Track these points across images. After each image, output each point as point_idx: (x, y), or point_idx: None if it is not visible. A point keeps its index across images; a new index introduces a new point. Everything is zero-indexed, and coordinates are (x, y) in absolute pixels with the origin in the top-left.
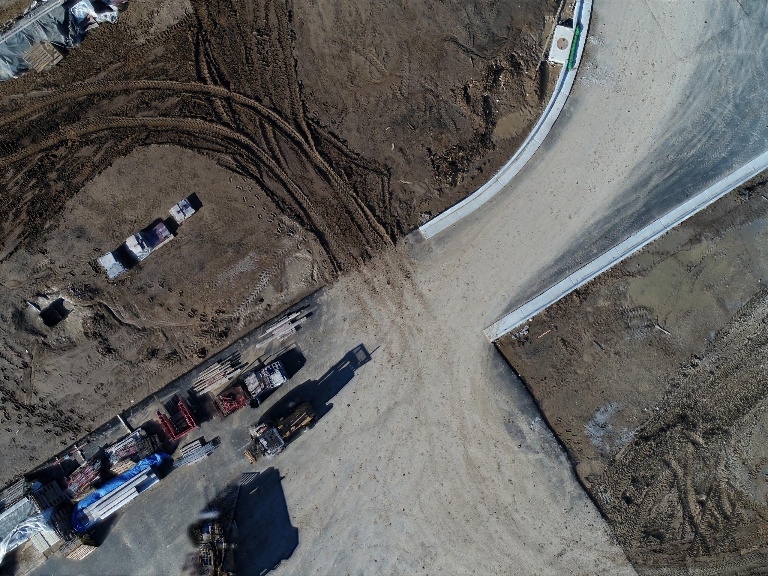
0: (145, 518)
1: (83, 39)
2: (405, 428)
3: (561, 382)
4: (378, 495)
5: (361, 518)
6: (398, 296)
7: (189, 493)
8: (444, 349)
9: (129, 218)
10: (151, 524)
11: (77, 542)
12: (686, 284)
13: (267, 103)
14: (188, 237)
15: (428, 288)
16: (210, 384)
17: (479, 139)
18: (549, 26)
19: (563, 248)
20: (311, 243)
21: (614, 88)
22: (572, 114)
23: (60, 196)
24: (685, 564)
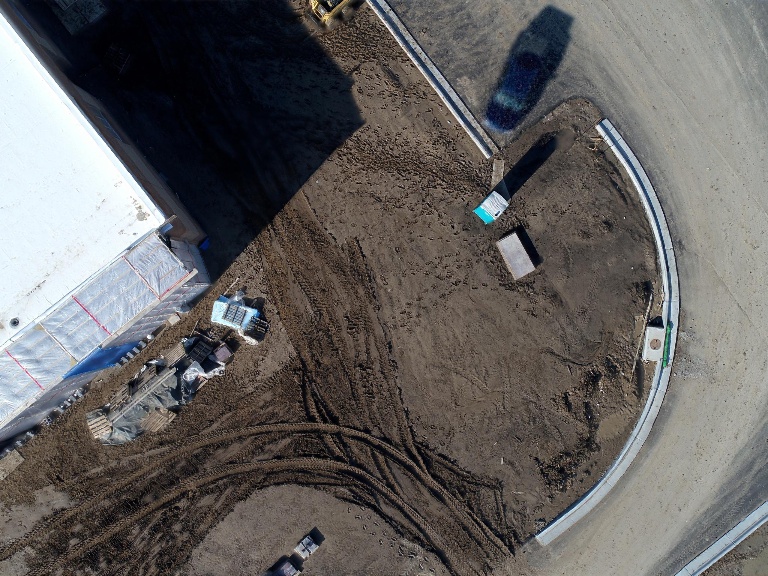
0: None
1: (195, 397)
2: None
3: None
4: None
5: None
6: None
7: None
8: None
9: (255, 558)
10: None
11: None
12: None
13: (377, 433)
14: (314, 570)
15: None
16: None
17: (584, 445)
18: (639, 325)
19: (676, 540)
20: (433, 562)
21: (709, 380)
22: (671, 409)
23: (187, 545)
24: None
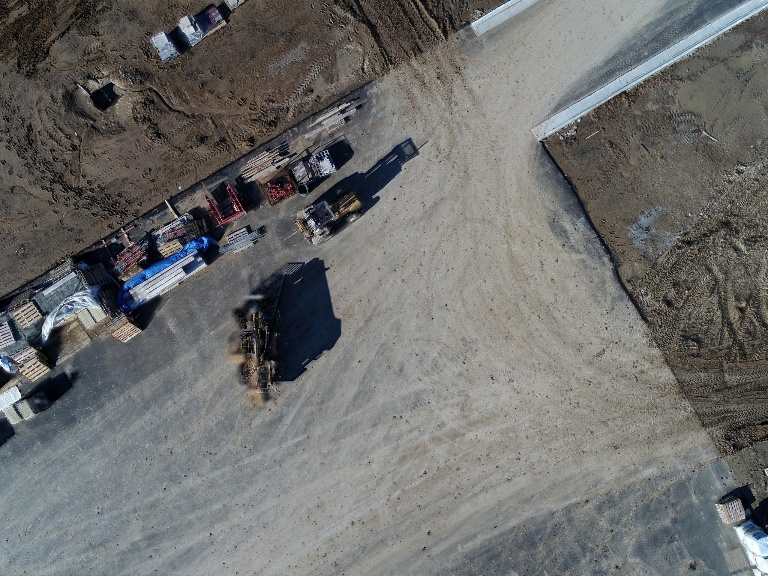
0: (190, 304)
1: None
2: (450, 224)
3: (607, 184)
4: (421, 290)
5: (404, 312)
6: (448, 92)
7: (234, 281)
8: (492, 147)
9: (182, 3)
10: (195, 310)
11: (123, 320)
12: (735, 91)
13: None
14: (240, 25)
15: (478, 85)
16: (258, 171)
17: None
18: None
19: (614, 49)
20: (363, 35)
21: None
22: None
23: None
24: (722, 370)
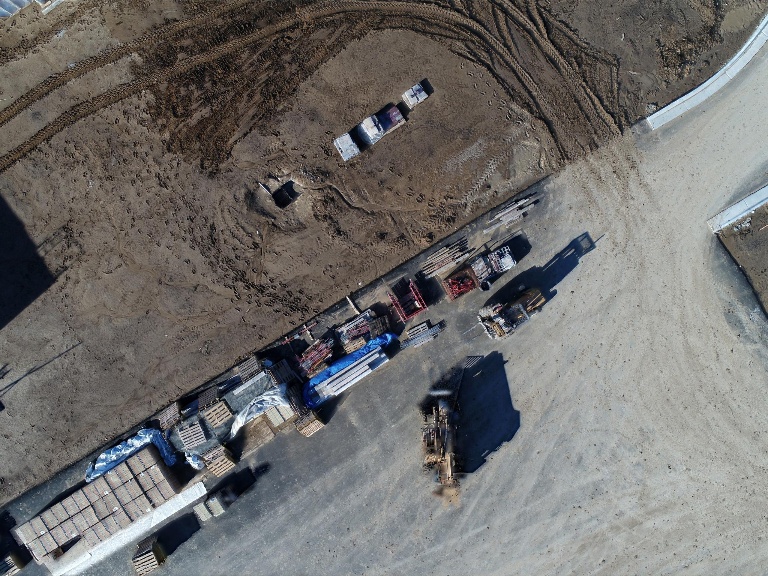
0: (371, 398)
1: None
2: (627, 316)
3: None
4: (599, 381)
5: (581, 403)
6: (624, 185)
7: (414, 375)
8: (667, 239)
9: (361, 102)
10: (377, 404)
11: (311, 417)
12: None
13: None
14: (419, 122)
15: (653, 178)
16: (439, 267)
17: (709, 31)
18: None
19: None
20: (539, 131)
21: None
22: None
23: (294, 78)
24: None
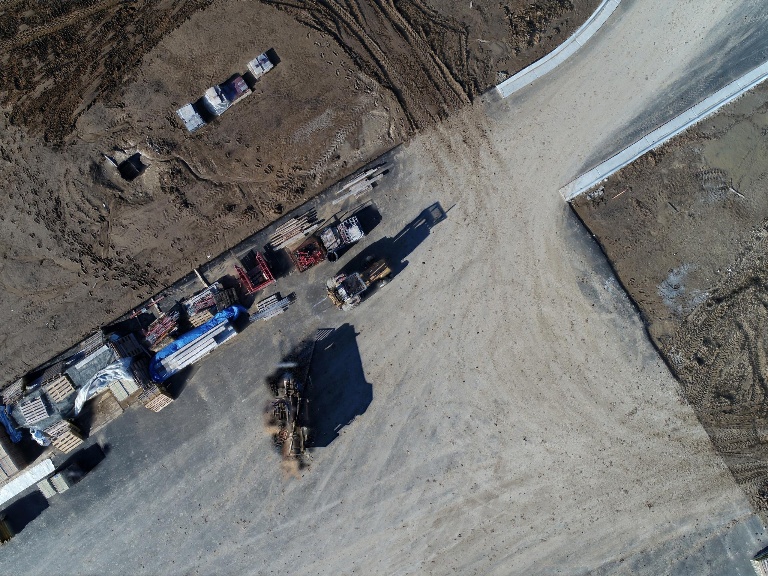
0: (221, 372)
1: None
2: (480, 286)
3: (635, 243)
4: (452, 353)
5: (435, 375)
6: (474, 155)
7: (265, 348)
8: (519, 208)
9: (207, 73)
10: (227, 378)
11: (156, 391)
12: (761, 147)
13: None
14: (266, 93)
15: (504, 147)
16: (287, 239)
17: None
18: None
19: (639, 109)
20: (388, 100)
21: None
22: None
23: (138, 49)
24: (754, 425)
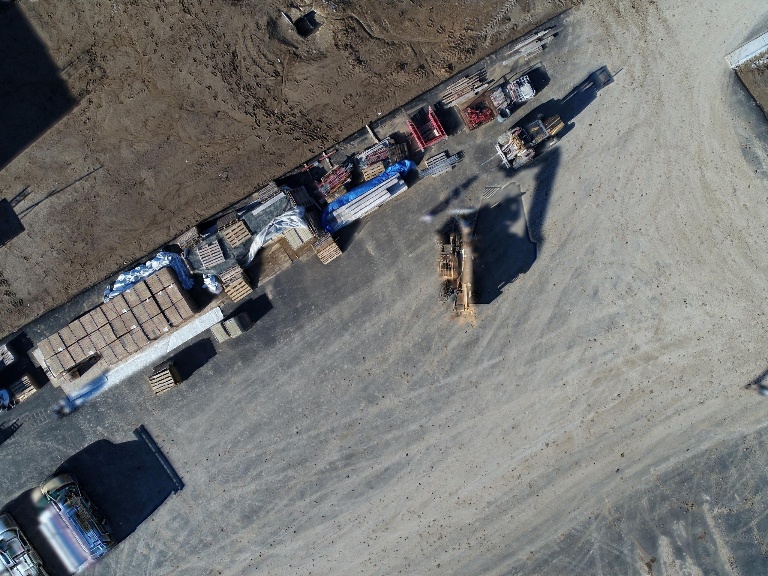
0: (388, 227)
1: None
2: (645, 150)
3: None
4: (616, 214)
5: (598, 236)
6: (642, 20)
7: (432, 205)
8: (685, 74)
9: None
10: (394, 233)
11: (329, 240)
12: None
13: None
14: None
15: (672, 13)
16: (459, 96)
17: None
18: None
19: None
20: None
21: None
22: None
23: None
24: None
